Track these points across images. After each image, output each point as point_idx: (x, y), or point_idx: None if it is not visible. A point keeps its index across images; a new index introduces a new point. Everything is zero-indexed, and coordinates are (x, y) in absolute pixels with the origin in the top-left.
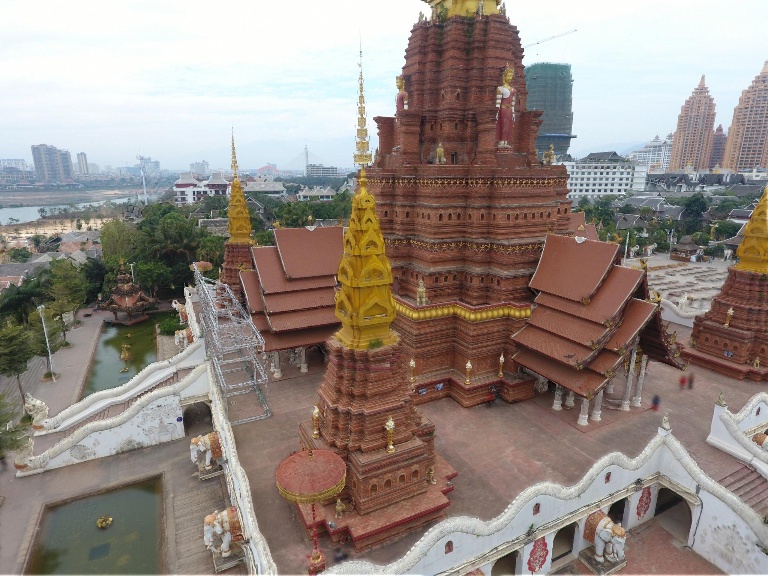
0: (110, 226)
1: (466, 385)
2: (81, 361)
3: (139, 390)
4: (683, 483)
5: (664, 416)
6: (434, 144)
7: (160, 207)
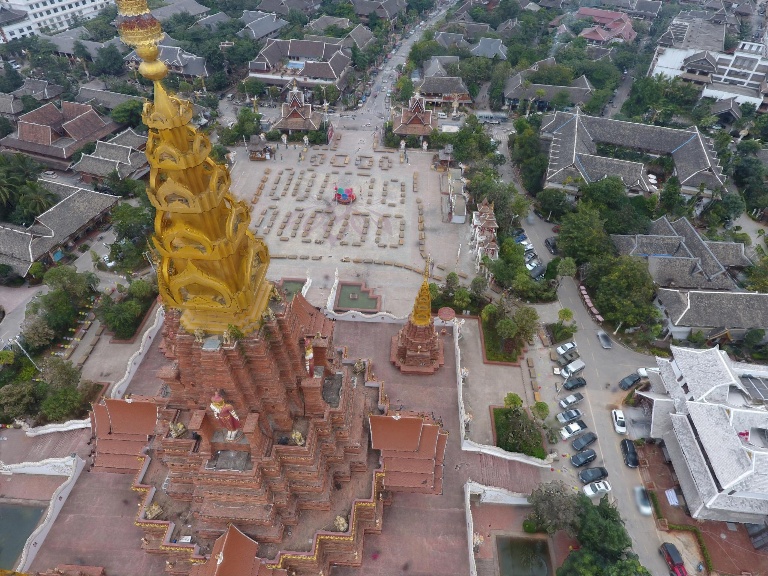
0: None
1: (379, 527)
2: None
3: None
4: (478, 491)
5: (469, 479)
6: (267, 416)
7: None
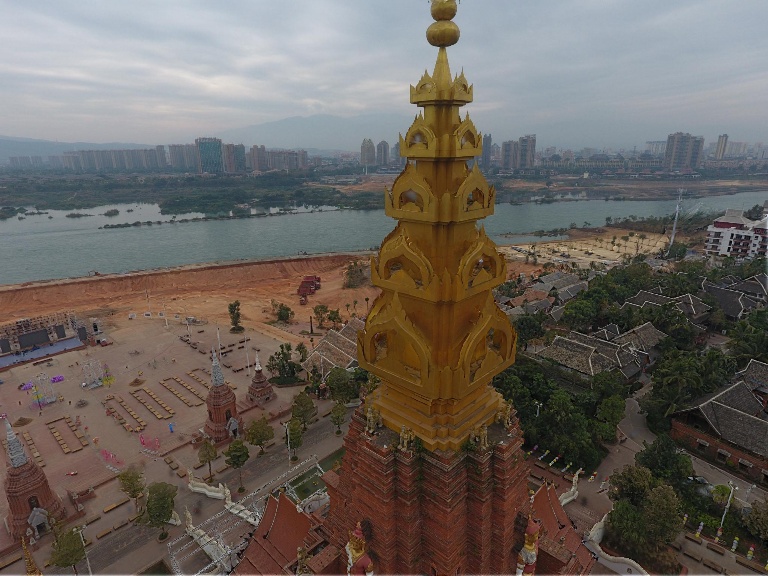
0: None
1: None
2: (320, 455)
3: (252, 522)
4: None
5: None
6: None
7: (601, 282)
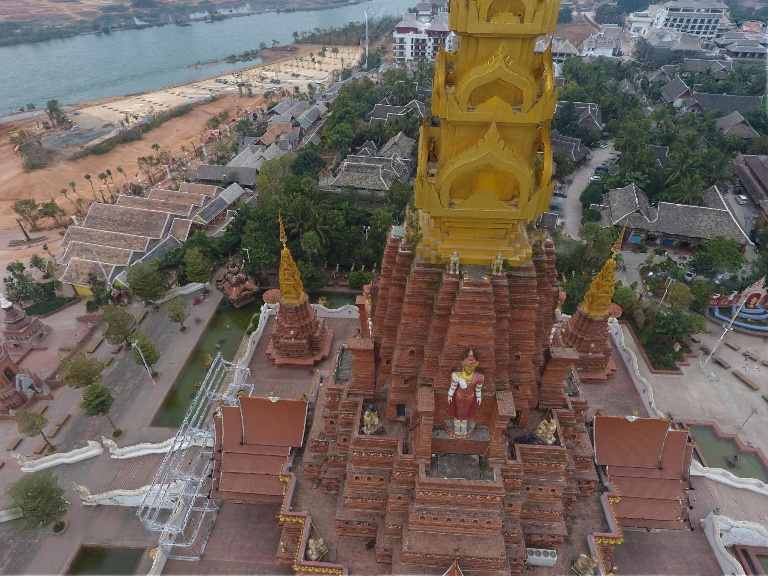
0: (266, 166)
1: None
2: (181, 359)
3: None
4: None
5: None
6: None
7: (344, 102)
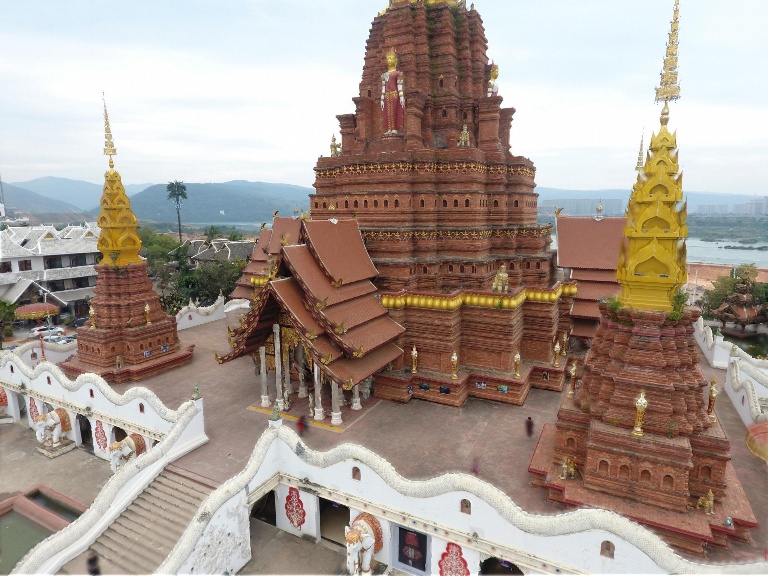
0: None
1: None
2: None
3: None
4: None
5: None
6: None
7: None
